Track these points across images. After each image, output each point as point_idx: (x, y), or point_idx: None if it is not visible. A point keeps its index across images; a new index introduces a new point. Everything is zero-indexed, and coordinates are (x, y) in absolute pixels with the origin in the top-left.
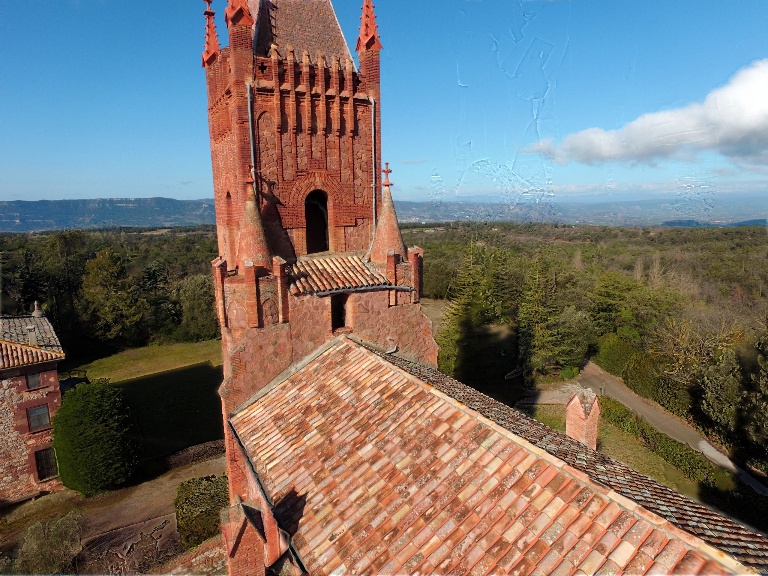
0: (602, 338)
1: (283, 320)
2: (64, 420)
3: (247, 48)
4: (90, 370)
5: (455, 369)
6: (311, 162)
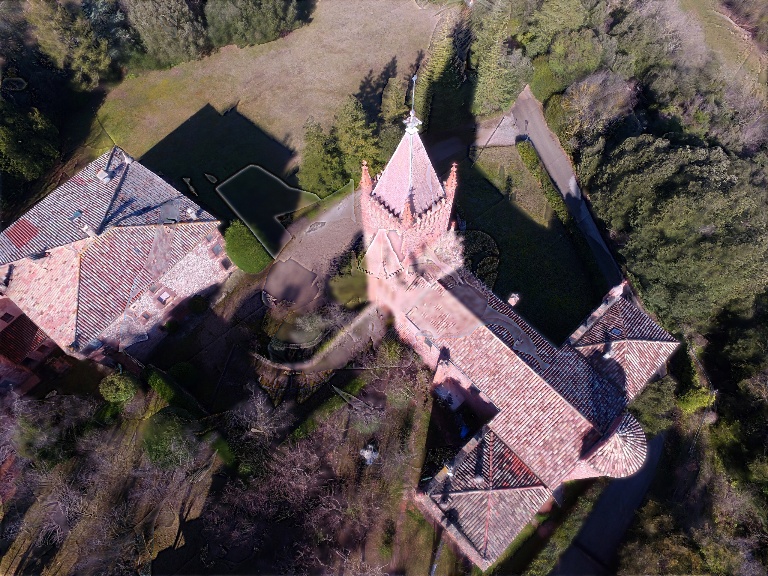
0: (537, 62)
1: None
2: (236, 251)
3: None
4: (110, 130)
5: (429, 123)
6: None
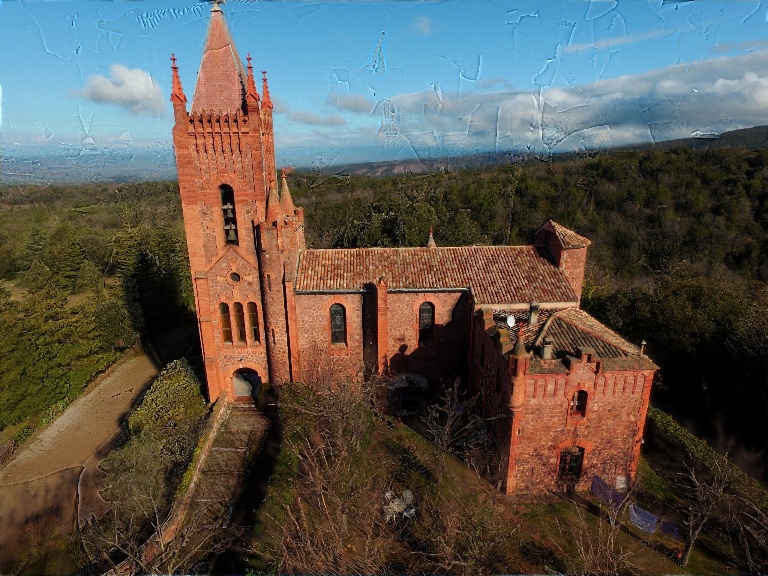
0: None
1: None
2: None
3: None
4: None
5: (145, 318)
6: None
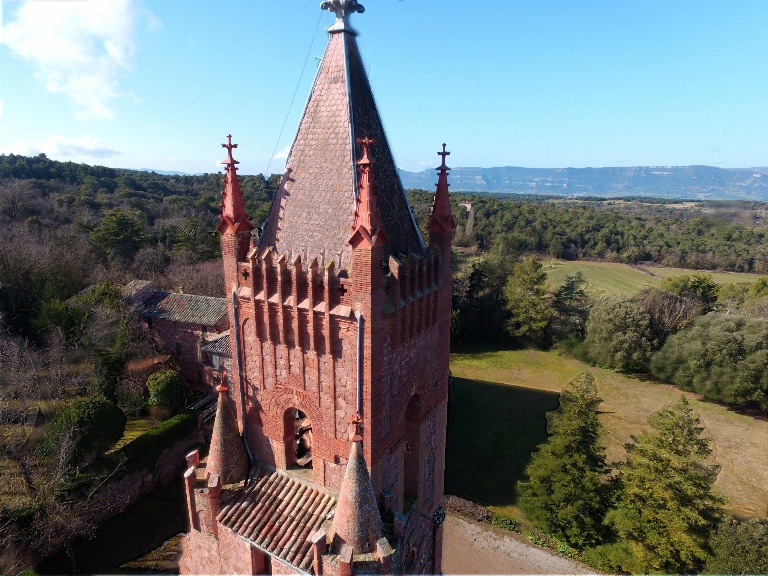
0: None
1: (215, 535)
2: None
3: (233, 256)
4: (489, 360)
5: None
6: (289, 377)
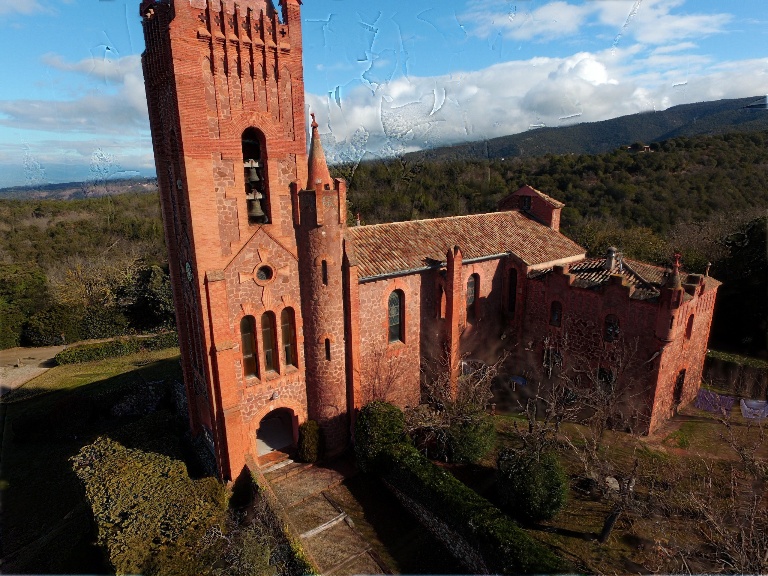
0: None
1: None
2: None
3: None
4: None
5: None
6: None
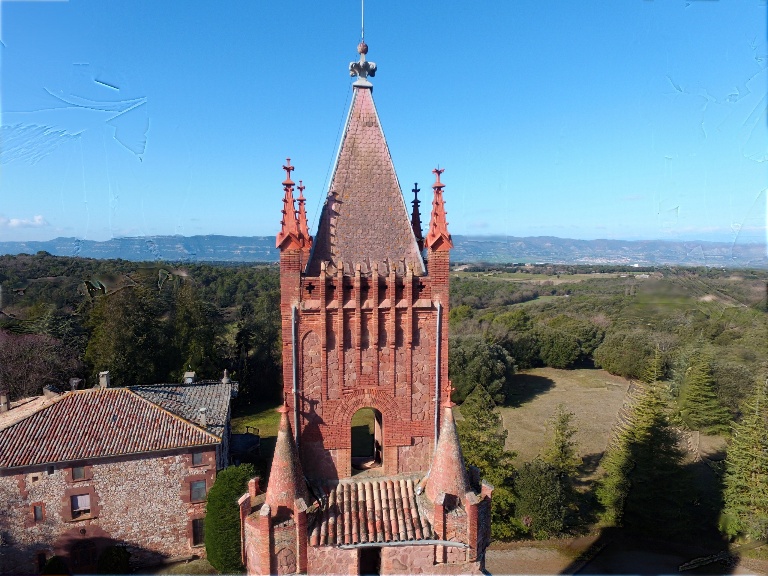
0: None
1: (300, 571)
2: (212, 500)
3: (294, 271)
4: (274, 416)
5: (624, 509)
6: (360, 378)
